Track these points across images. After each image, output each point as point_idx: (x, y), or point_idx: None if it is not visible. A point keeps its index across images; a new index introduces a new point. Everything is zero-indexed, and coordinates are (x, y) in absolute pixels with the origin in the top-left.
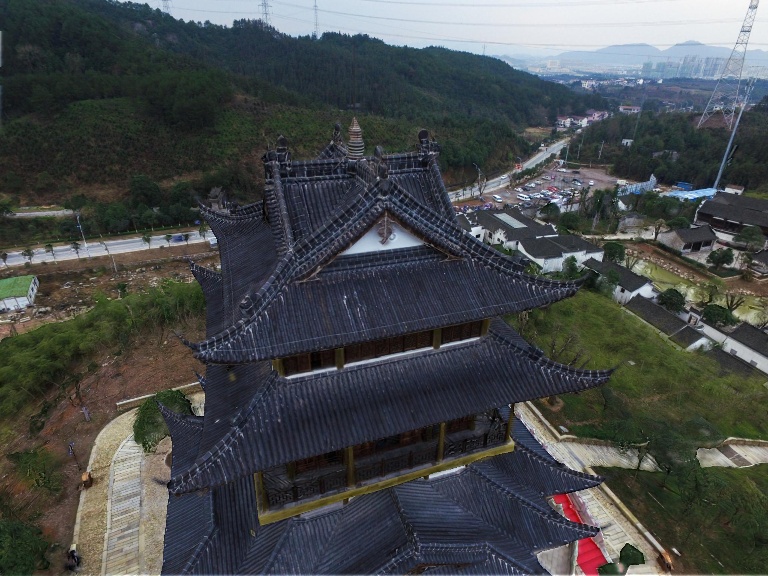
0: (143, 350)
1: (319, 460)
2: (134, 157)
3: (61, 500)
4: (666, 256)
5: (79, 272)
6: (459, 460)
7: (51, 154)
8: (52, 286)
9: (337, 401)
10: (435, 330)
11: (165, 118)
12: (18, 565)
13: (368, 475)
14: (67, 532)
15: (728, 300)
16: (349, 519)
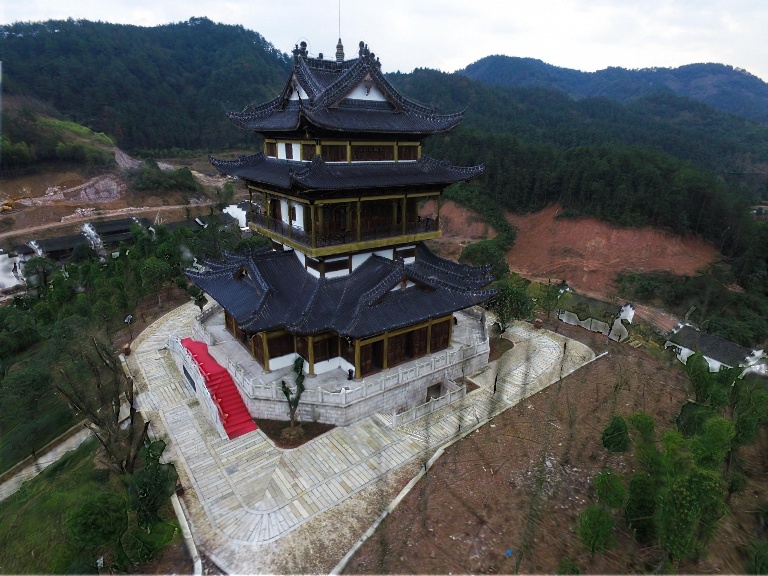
0: None
1: None
2: None
3: None
4: None
5: None
6: None
7: None
8: None
9: None
10: None
11: None
12: None
13: None
14: None
15: None
16: None
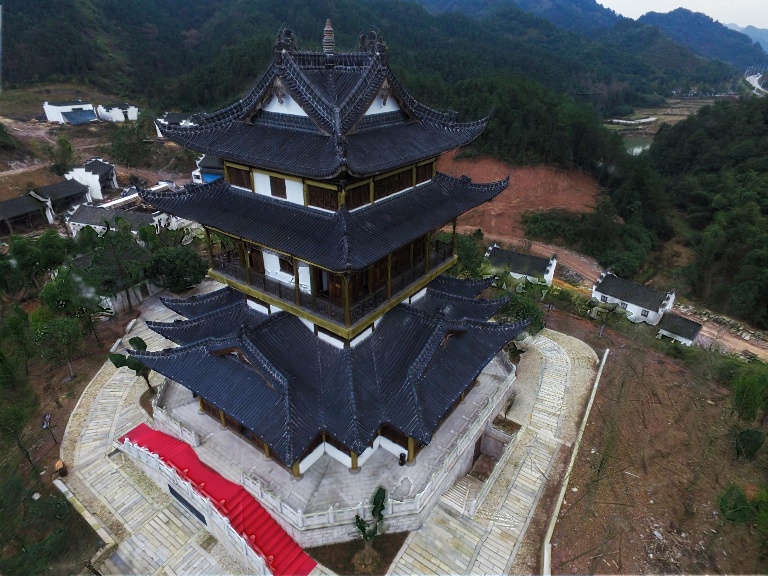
0: None
1: None
2: None
3: None
4: None
5: None
6: None
7: None
8: None
9: None
10: None
11: None
12: None
13: None
14: None
15: None
16: None
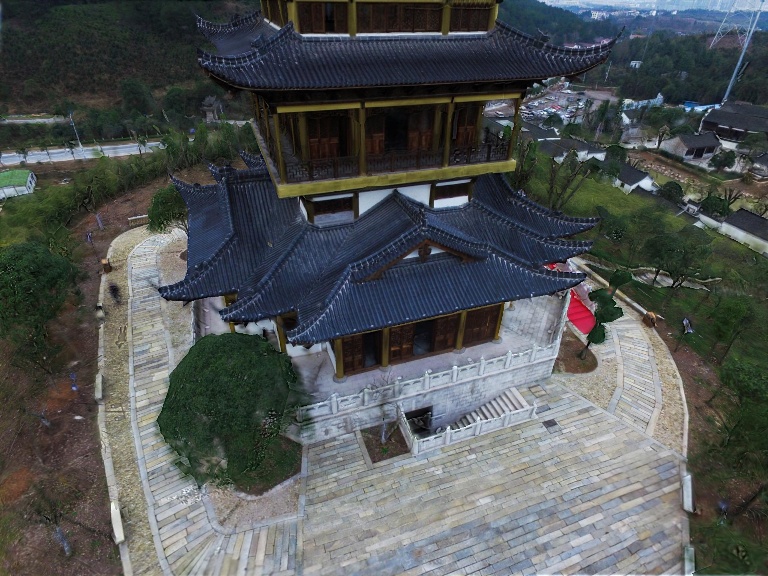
0: (150, 186)
1: (332, 157)
2: (123, 67)
3: (83, 279)
4: (668, 163)
5: (76, 172)
6: (464, 168)
7: (36, 61)
8: (50, 182)
9: (350, 58)
10: (444, 10)
11: (153, 26)
12: (53, 267)
13: (378, 167)
14: (92, 298)
15: (726, 194)
16: (360, 230)
